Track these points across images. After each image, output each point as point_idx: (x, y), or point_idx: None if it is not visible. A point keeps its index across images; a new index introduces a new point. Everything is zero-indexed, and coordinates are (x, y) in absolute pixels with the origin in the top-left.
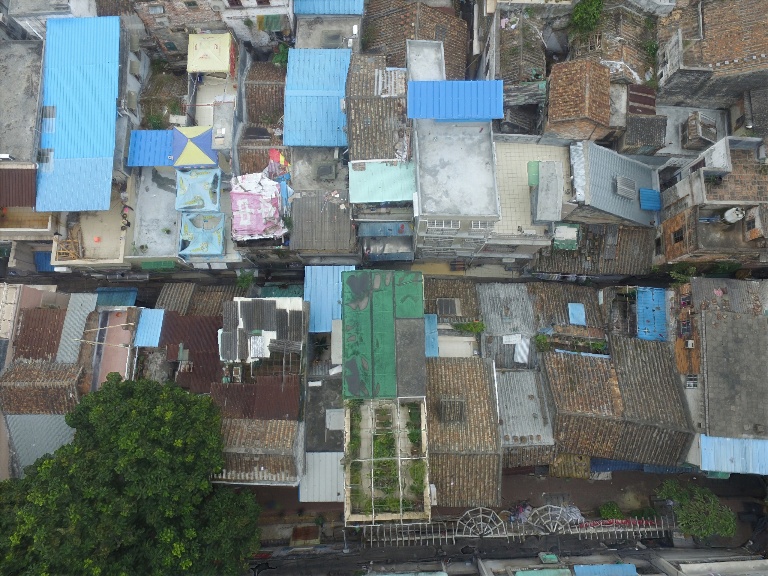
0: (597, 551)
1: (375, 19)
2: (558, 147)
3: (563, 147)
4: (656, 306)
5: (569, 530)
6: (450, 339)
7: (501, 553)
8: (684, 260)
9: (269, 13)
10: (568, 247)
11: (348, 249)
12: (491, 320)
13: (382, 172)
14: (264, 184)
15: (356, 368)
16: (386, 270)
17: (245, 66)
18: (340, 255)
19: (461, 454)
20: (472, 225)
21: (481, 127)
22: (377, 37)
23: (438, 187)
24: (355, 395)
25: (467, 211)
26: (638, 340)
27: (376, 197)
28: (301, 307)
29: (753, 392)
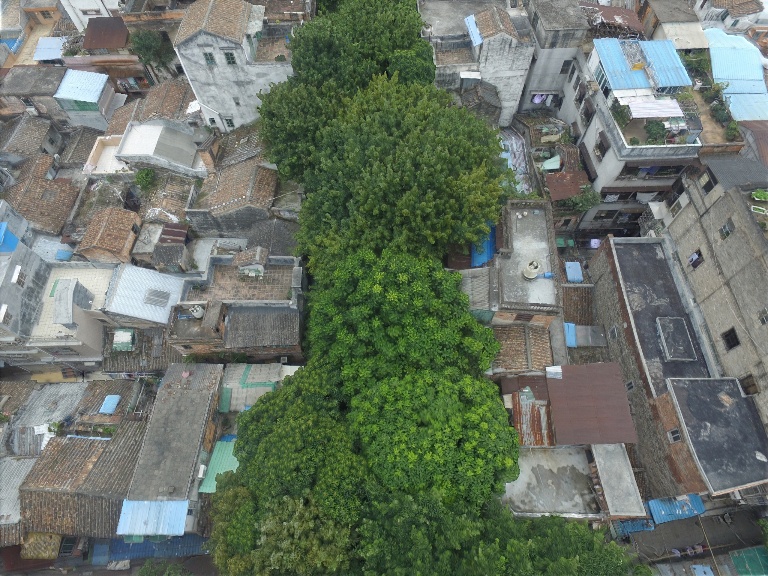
0: None
1: (10, 188)
2: (113, 270)
3: None
4: None
5: None
6: None
7: None
8: (191, 352)
9: None
10: (124, 349)
11: None
12: (34, 414)
13: None
14: None
15: None
16: None
17: None
18: None
19: None
20: None
21: (10, 256)
22: (5, 199)
23: None
24: None
25: None
26: (143, 423)
27: None
28: None
29: (178, 457)
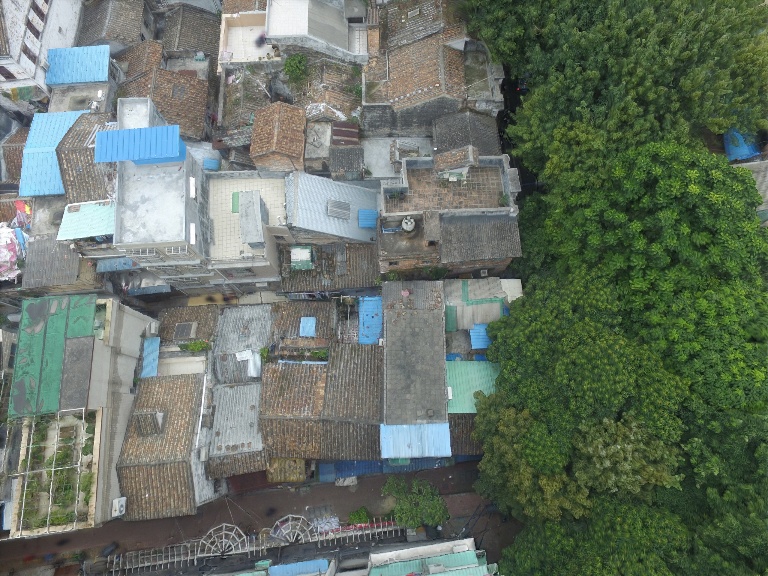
0: (321, 554)
1: (126, 84)
2: (280, 179)
3: (284, 179)
4: (375, 313)
5: (309, 538)
6: (183, 360)
7: (230, 567)
8: (392, 269)
9: (21, 85)
10: (304, 267)
11: (90, 285)
12: (229, 340)
13: (94, 212)
14: (2, 232)
15: (24, 387)
16: (63, 296)
17: (9, 132)
18: (88, 292)
19: (151, 465)
20: (166, 251)
21: (180, 166)
22: None
23: (137, 220)
24: (19, 413)
25: (161, 239)
26: (355, 345)
27: (82, 234)
28: (1, 338)
29: (427, 380)
